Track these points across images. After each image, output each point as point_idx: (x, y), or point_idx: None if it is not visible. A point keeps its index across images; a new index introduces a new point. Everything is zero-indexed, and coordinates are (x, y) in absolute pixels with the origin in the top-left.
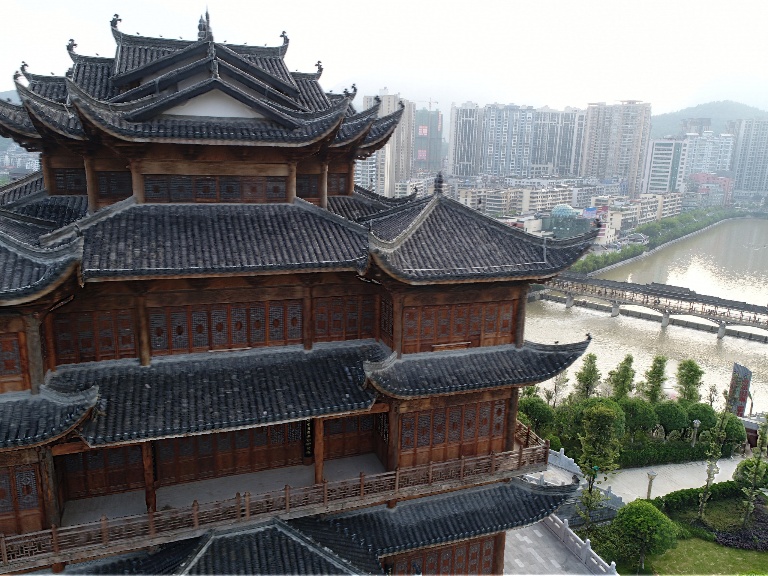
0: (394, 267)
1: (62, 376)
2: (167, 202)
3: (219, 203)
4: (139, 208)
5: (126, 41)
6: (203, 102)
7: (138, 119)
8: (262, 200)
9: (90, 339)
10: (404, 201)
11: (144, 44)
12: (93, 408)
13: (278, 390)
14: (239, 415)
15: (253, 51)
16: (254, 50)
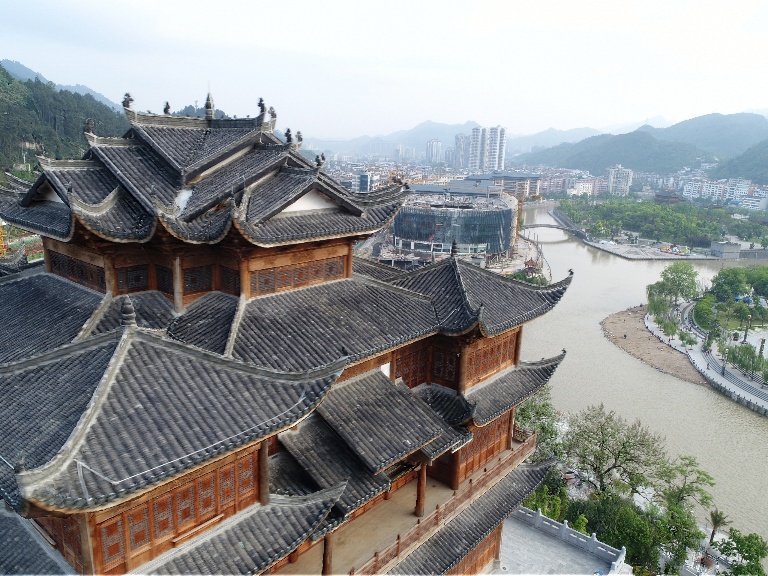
0: None
1: None
2: (59, 275)
3: (78, 284)
4: (40, 277)
5: None
6: (53, 191)
7: (24, 205)
8: (97, 288)
9: None
10: (474, 316)
11: None
12: None
13: None
14: None
15: (239, 124)
16: (240, 123)
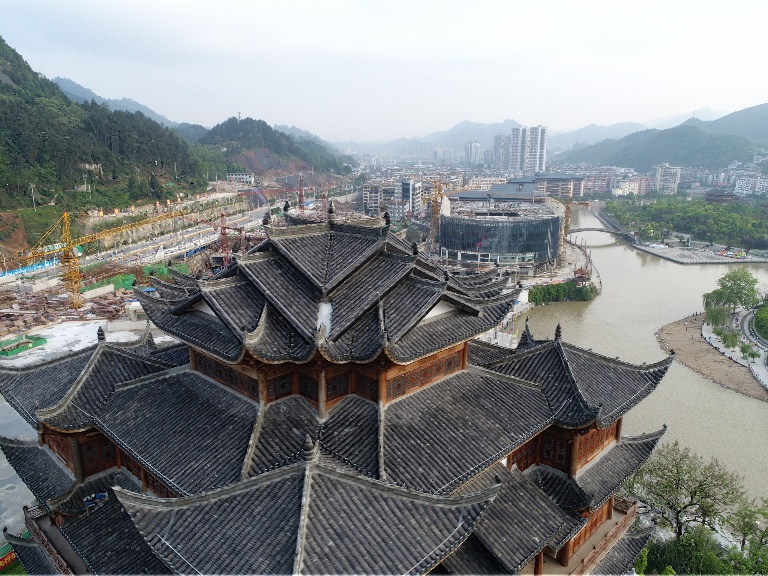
0: (145, 527)
1: (116, 474)
2: (205, 374)
3: (226, 386)
4: (186, 374)
5: (291, 221)
6: (207, 306)
7: (176, 314)
8: (247, 394)
9: (130, 458)
10: (591, 412)
11: (300, 224)
12: (58, 510)
13: (145, 570)
14: (106, 571)
15: (363, 231)
16: (363, 230)
